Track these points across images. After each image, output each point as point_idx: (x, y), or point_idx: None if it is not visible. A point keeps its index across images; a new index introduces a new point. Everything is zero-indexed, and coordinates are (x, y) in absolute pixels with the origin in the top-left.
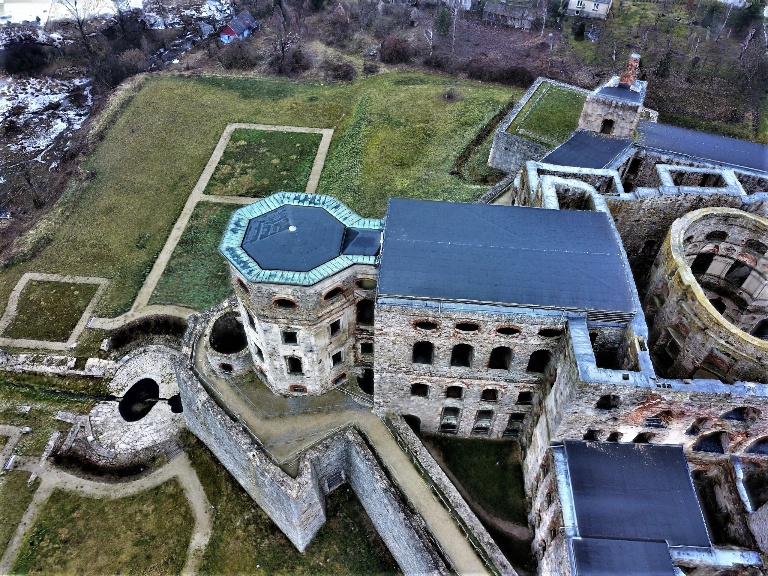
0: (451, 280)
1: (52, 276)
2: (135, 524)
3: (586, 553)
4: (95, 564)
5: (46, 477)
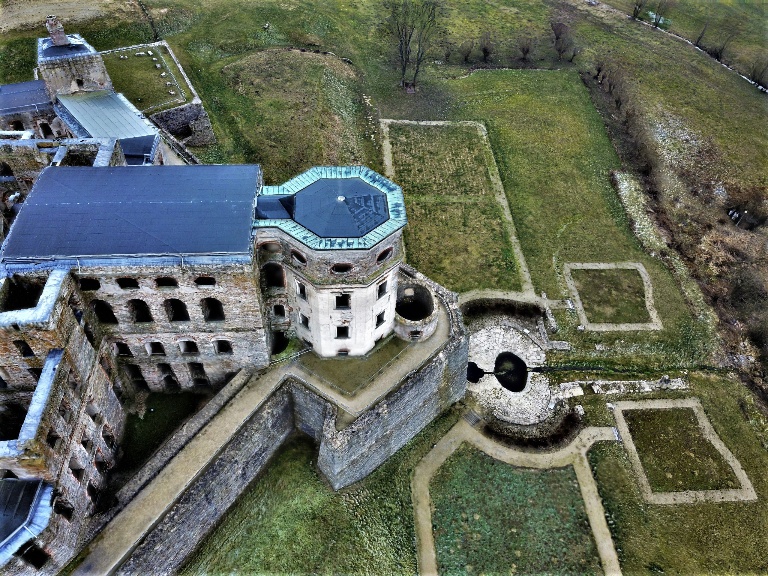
0: (197, 176)
1: (721, 497)
2: (451, 277)
3: (144, 150)
4: (463, 257)
5: (535, 297)
